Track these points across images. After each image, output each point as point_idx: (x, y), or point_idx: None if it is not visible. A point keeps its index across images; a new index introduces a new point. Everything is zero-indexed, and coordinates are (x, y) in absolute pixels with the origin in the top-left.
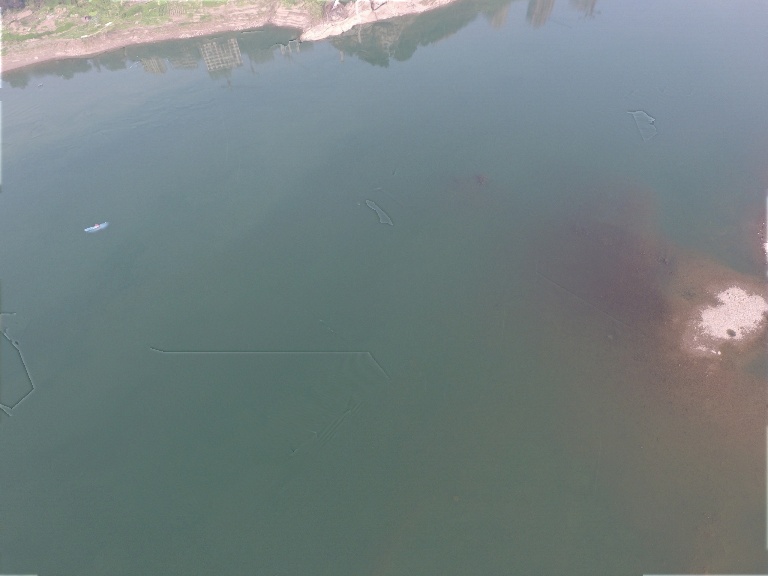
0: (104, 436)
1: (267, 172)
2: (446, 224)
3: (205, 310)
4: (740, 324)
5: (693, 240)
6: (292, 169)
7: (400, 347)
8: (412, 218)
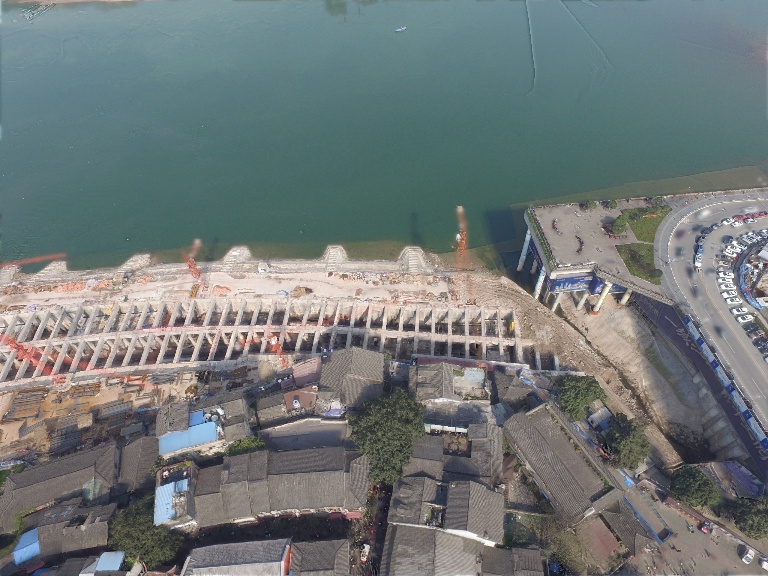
0: (542, 26)
1: (494, 3)
2: (611, 26)
3: (489, 59)
4: None
5: (763, 26)
6: (507, 2)
7: None
8: (591, 22)
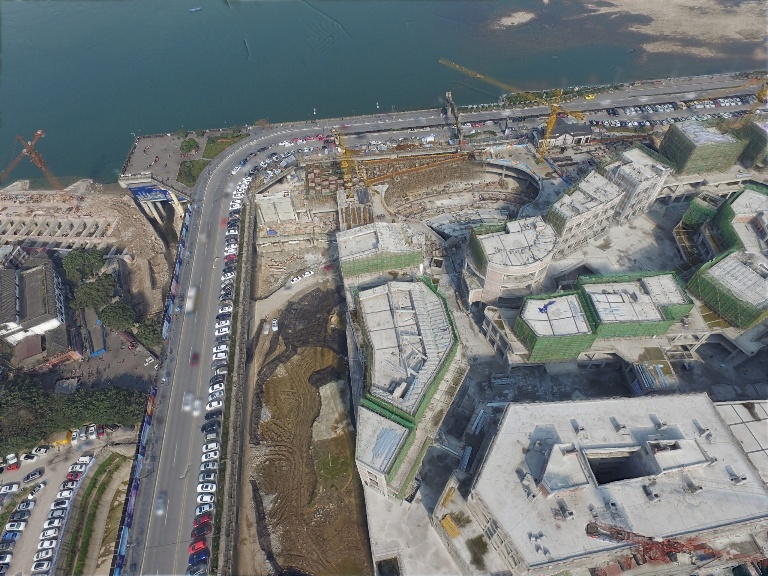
0: None
1: None
2: (383, 4)
3: None
4: (518, 21)
5: (509, 0)
6: None
7: (357, 39)
8: (365, 0)
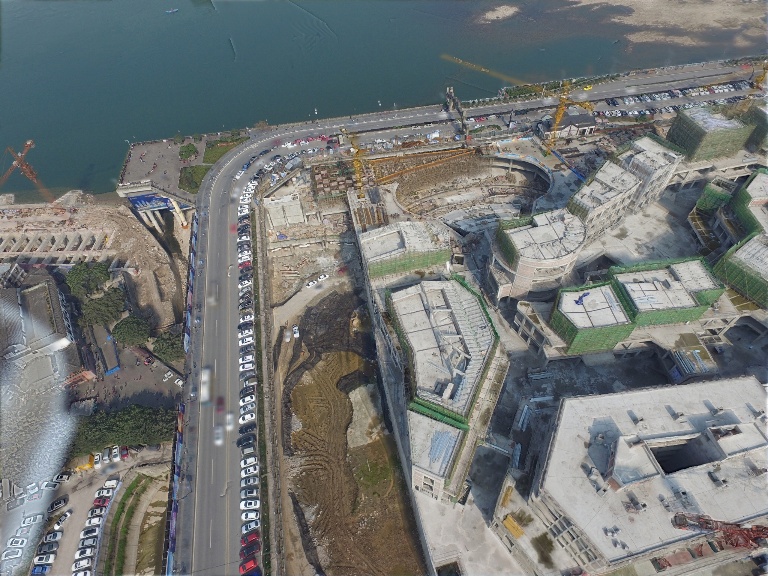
0: None
1: None
2: (365, 1)
3: None
4: (503, 15)
5: None
6: None
7: (342, 37)
8: None
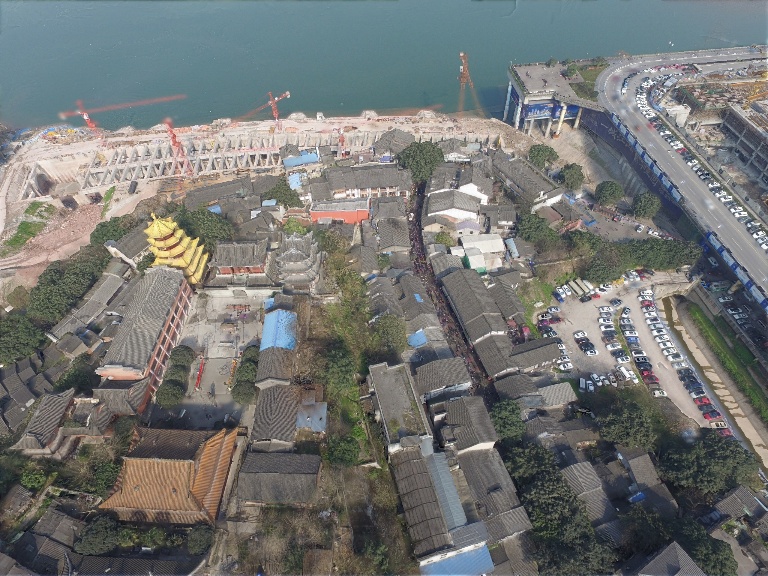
0: None
1: None
2: None
3: None
4: None
5: None
6: None
7: None
8: None
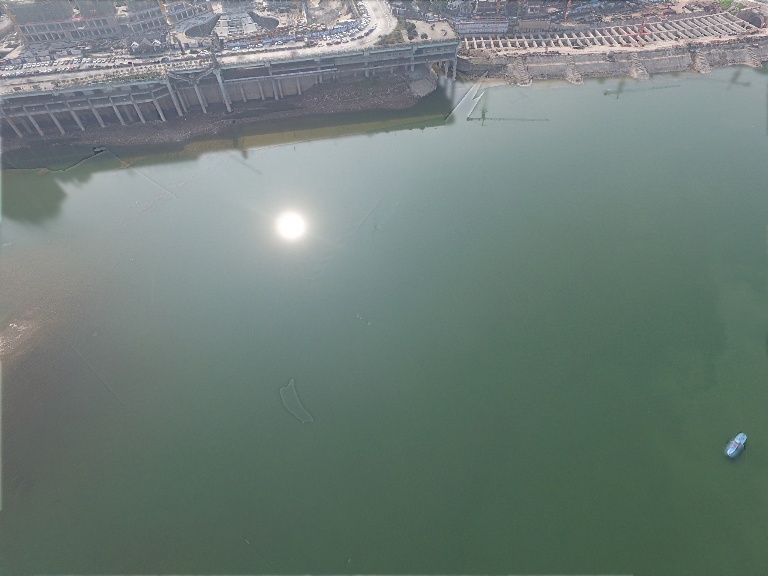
0: None
1: None
2: (210, 500)
3: (501, 342)
4: None
5: None
6: None
7: (296, 324)
8: (259, 498)
